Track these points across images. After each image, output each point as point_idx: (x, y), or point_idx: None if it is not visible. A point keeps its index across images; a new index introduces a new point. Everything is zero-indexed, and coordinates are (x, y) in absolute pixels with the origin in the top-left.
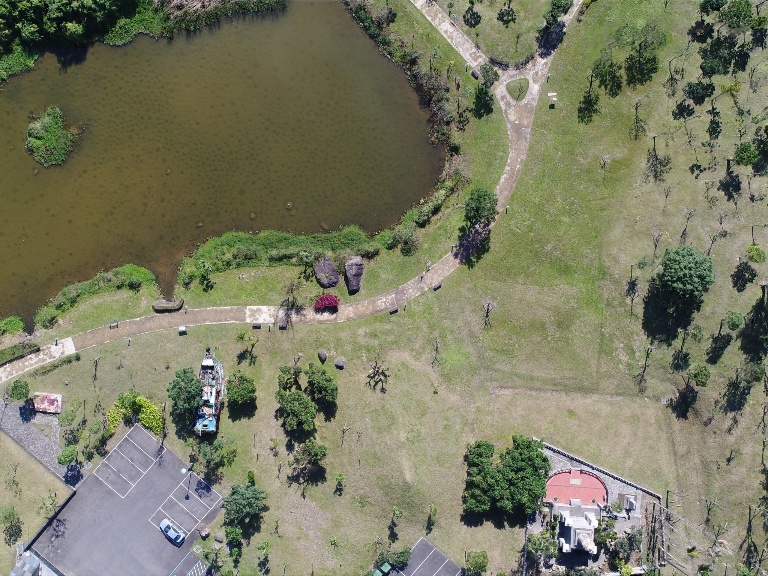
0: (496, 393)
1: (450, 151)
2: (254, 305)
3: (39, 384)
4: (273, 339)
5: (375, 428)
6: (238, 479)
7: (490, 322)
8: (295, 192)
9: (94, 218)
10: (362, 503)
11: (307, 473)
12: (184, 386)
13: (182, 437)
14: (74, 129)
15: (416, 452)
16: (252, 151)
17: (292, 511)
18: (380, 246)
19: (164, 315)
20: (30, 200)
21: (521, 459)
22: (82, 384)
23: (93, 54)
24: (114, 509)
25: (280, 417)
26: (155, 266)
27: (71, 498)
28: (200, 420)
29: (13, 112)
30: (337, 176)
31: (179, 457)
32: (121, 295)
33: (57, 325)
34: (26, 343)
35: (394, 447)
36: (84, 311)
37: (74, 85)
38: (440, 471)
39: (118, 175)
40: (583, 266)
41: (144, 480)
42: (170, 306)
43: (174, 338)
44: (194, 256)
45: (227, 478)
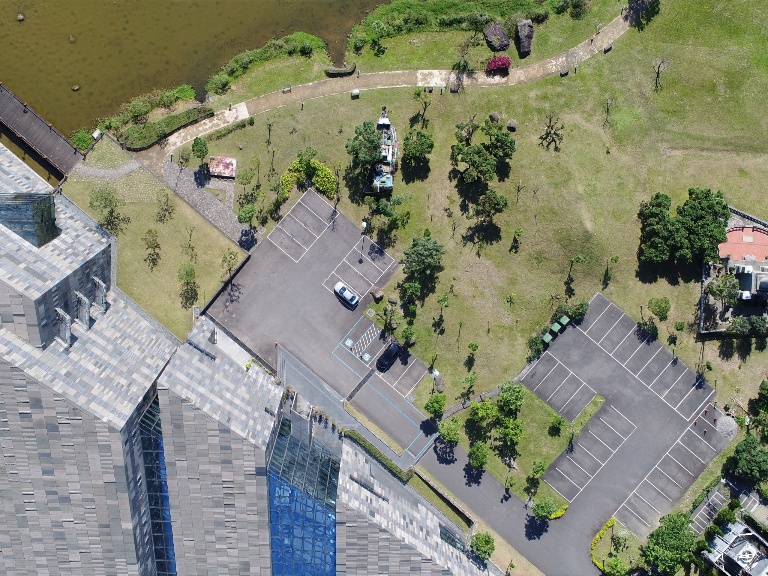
0: (667, 154)
1: None
2: (426, 69)
3: (213, 149)
4: (445, 102)
5: (551, 184)
6: (412, 241)
7: (660, 83)
8: None
9: None
10: (538, 259)
11: (482, 233)
12: (367, 136)
13: (355, 201)
14: None
15: (594, 205)
16: None
17: (467, 270)
18: (549, 10)
19: (336, 79)
20: None
21: (700, 208)
22: (256, 149)
23: None
24: (288, 273)
25: (454, 178)
26: (325, 34)
27: (245, 263)
28: (378, 177)
29: None
30: None
31: (352, 221)
32: (293, 61)
33: (230, 91)
34: (201, 107)
35: (572, 200)
36: (256, 77)
37: None
38: (616, 225)
39: None
40: (753, 26)
41: (318, 244)
42: (343, 70)
43: (347, 102)
44: (364, 23)
45: (400, 241)
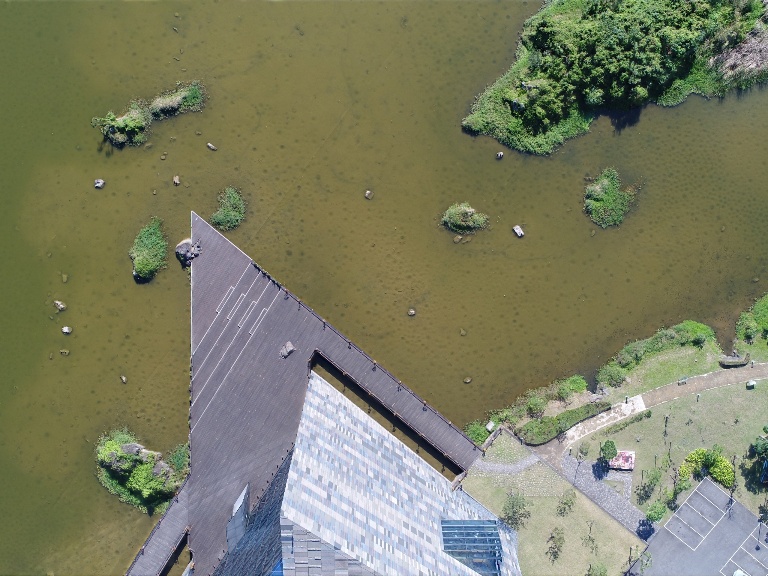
0: None
1: None
2: None
3: None
4: None
5: None
6: None
7: None
8: None
9: (651, 276)
10: None
11: None
12: None
13: (751, 489)
14: (630, 190)
15: None
16: None
17: None
18: None
19: (731, 370)
20: (588, 261)
21: None
22: (653, 440)
23: (645, 115)
24: (685, 561)
25: None
26: (713, 322)
27: (643, 552)
28: None
29: (569, 175)
30: None
31: (748, 509)
32: (686, 352)
33: (625, 383)
34: (599, 402)
35: None
36: (650, 368)
37: (628, 146)
38: None
39: (674, 233)
40: None
41: (714, 532)
42: (739, 361)
43: (742, 392)
44: (752, 311)
45: None
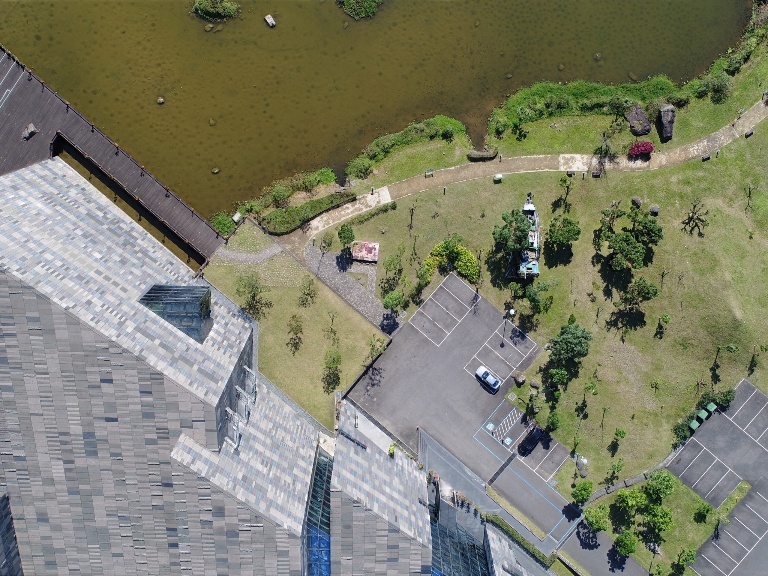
0: None
1: (757, 1)
2: (567, 153)
3: (356, 233)
4: (587, 187)
5: (697, 270)
6: (554, 325)
7: None
8: (603, 43)
9: (404, 70)
10: (684, 345)
11: (625, 318)
12: (518, 225)
13: (497, 285)
14: None
15: (741, 292)
16: (560, 3)
17: (611, 355)
18: None
19: (479, 164)
20: (340, 53)
21: None
22: (398, 233)
23: None
24: (429, 357)
25: (597, 263)
26: (465, 117)
27: (387, 347)
28: (524, 264)
29: None
30: (644, 27)
31: (494, 305)
32: (434, 145)
33: (372, 175)
34: (343, 192)
35: (720, 287)
36: (398, 161)
37: None
38: (763, 312)
39: (427, 27)
40: None
41: (459, 328)
42: (486, 154)
43: (489, 186)
44: (504, 107)
45: (543, 325)
